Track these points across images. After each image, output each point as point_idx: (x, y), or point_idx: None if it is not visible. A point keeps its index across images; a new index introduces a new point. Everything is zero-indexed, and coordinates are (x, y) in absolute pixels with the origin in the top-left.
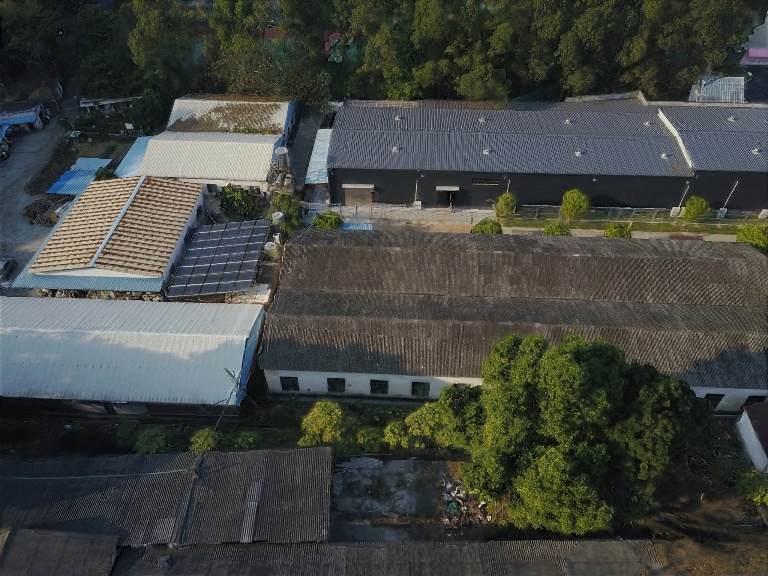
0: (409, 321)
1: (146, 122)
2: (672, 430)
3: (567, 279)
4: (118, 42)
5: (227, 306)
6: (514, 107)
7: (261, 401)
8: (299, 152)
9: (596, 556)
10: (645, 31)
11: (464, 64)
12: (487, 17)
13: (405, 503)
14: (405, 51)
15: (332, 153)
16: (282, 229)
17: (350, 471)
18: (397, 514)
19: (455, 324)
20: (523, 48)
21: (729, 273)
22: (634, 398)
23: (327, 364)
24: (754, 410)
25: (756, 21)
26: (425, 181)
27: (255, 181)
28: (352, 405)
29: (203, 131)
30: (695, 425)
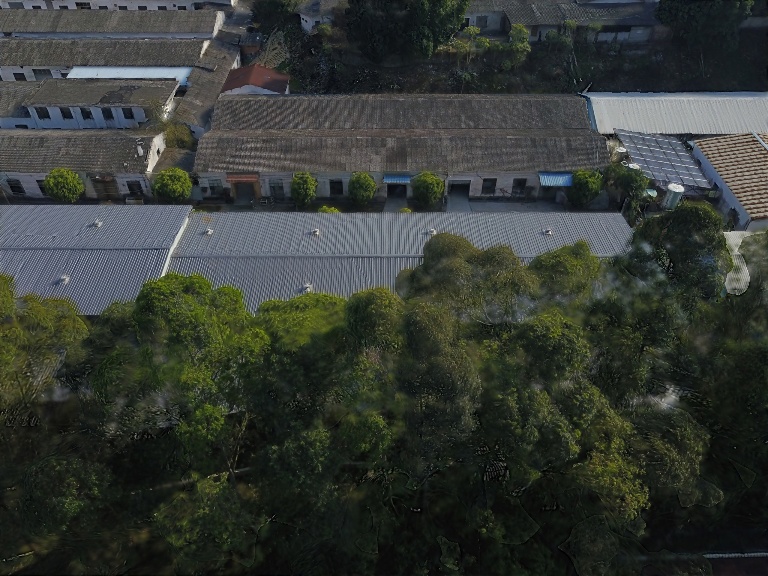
0: (487, 99)
1: None
2: None
3: None
4: None
5: None
6: None
7: None
8: None
9: None
10: None
11: None
12: None
13: None
14: None
15: (625, 226)
16: None
17: None
18: None
19: None
20: None
21: None
22: None
23: (532, 94)
24: (281, 90)
25: None
26: None
27: None
28: None
29: None
30: None
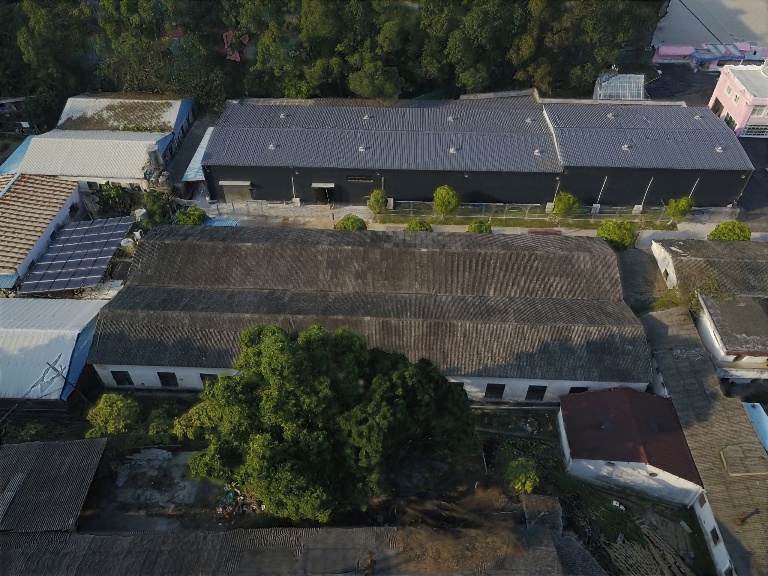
0: (241, 315)
1: (40, 120)
2: (390, 417)
3: (412, 274)
4: (14, 41)
5: (74, 302)
6: (408, 105)
7: (94, 395)
8: (187, 150)
9: (336, 542)
10: (534, 29)
11: (354, 62)
12: (373, 15)
13: (185, 493)
14: (295, 49)
15: (209, 150)
16: (144, 226)
17: (139, 462)
18: (174, 504)
19: (286, 318)
20: (416, 46)
21: (572, 267)
22: (369, 386)
23: (154, 358)
24: (567, 401)
25: (649, 19)
26: (300, 178)
27: (133, 178)
28: (181, 399)
29: (92, 129)
30: (446, 413)
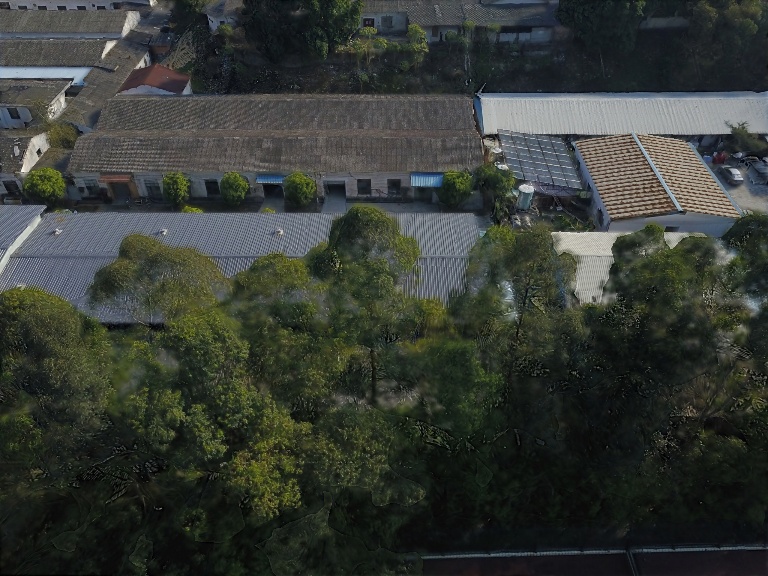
0: (375, 99)
1: None
2: None
3: None
4: None
5: None
6: None
7: None
8: None
9: None
10: None
11: None
12: None
13: None
14: None
15: (473, 226)
16: None
17: None
18: None
19: (344, 99)
20: None
21: None
22: None
23: None
24: (178, 91)
25: None
26: None
27: None
28: None
29: None
30: None
